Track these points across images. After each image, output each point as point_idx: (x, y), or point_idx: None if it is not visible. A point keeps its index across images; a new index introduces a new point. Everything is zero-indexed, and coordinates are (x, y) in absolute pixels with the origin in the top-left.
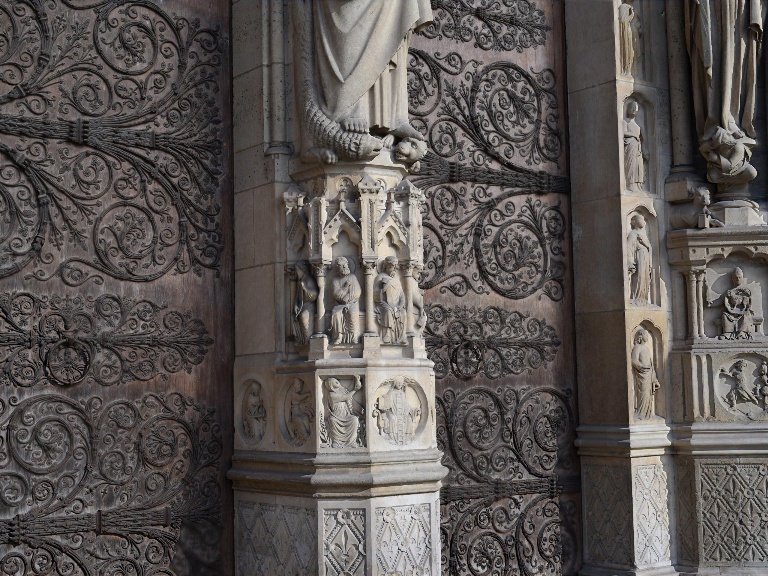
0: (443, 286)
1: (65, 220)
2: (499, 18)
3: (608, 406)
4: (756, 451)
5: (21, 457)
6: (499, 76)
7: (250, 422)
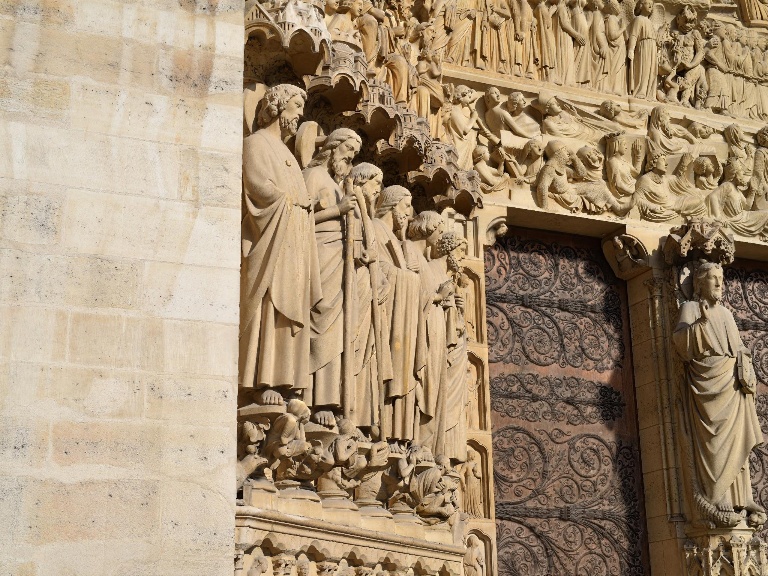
0: None
1: (561, 564)
2: None
3: None
4: None
5: None
6: None
7: None
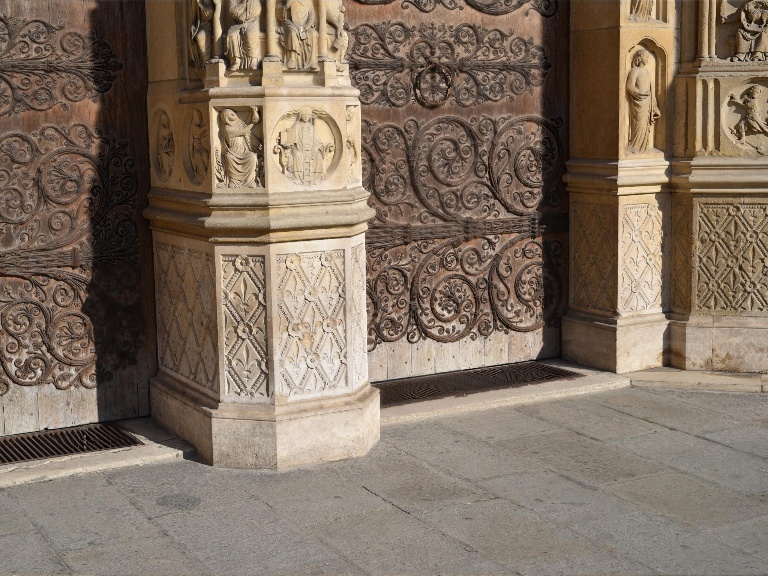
0: (405, 0)
1: None
2: None
3: (598, 138)
4: (763, 190)
5: None
6: None
7: (161, 157)
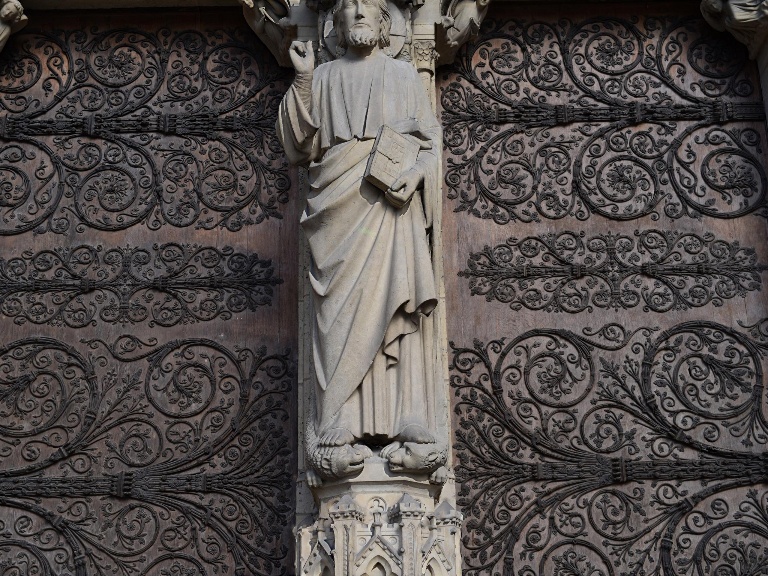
0: None
1: None
2: (679, 270)
3: None
4: None
5: None
6: (687, 340)
7: None
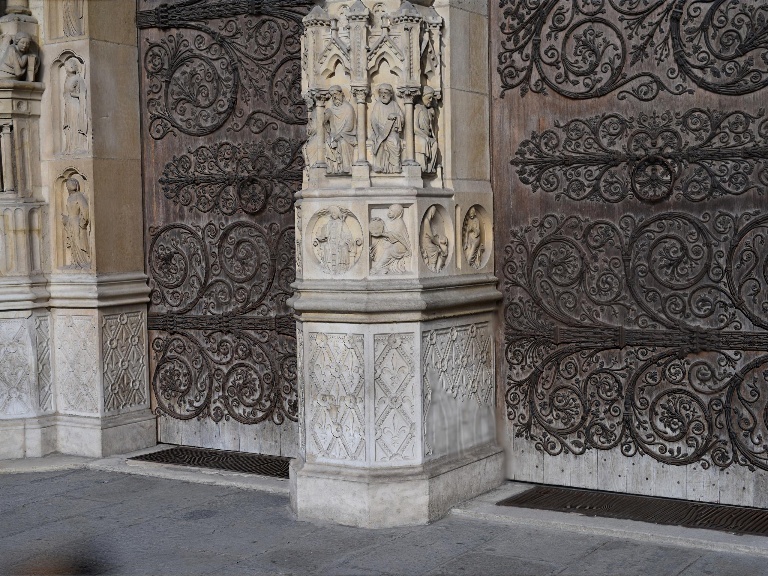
0: (622, 91)
1: (250, 80)
2: None
3: None
4: None
5: (228, 268)
6: None
7: None
